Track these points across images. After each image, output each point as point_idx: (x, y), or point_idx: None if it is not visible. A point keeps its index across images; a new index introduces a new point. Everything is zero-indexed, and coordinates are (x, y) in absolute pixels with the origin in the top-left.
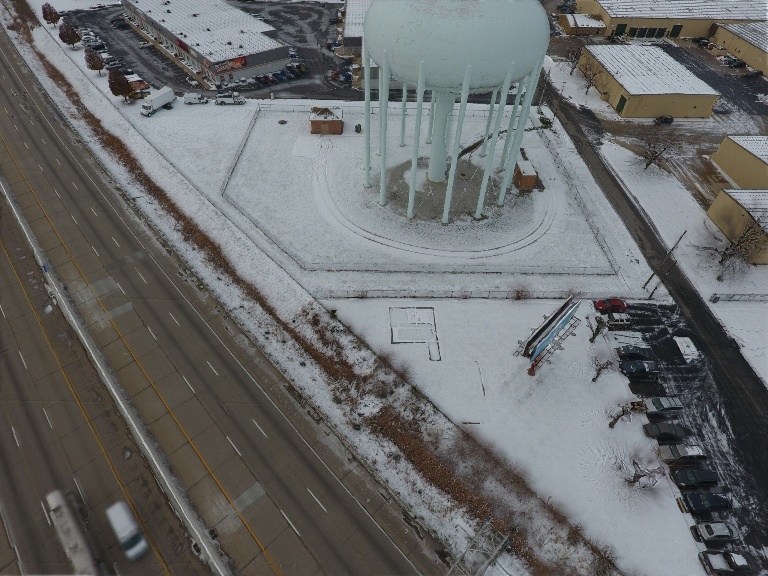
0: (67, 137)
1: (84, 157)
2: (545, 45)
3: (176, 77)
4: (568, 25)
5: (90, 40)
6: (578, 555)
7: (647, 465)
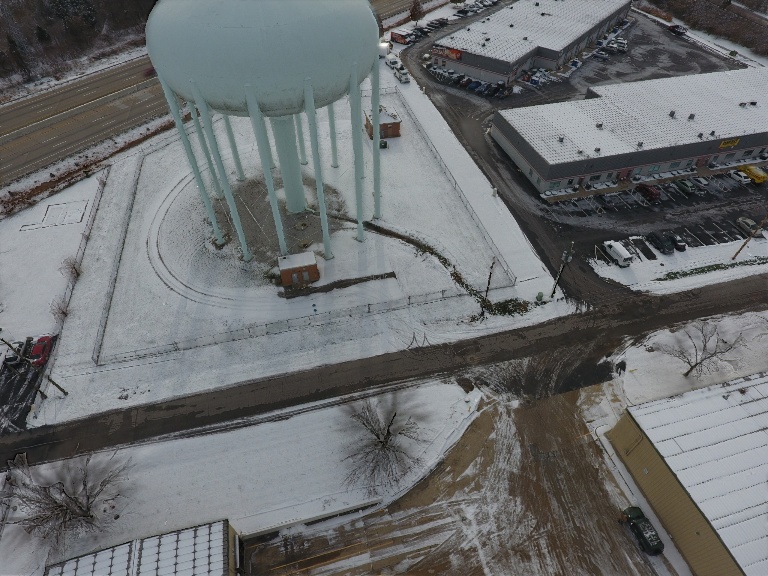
0: None
1: None
2: (200, 75)
3: None
4: None
5: (469, 5)
6: None
7: None
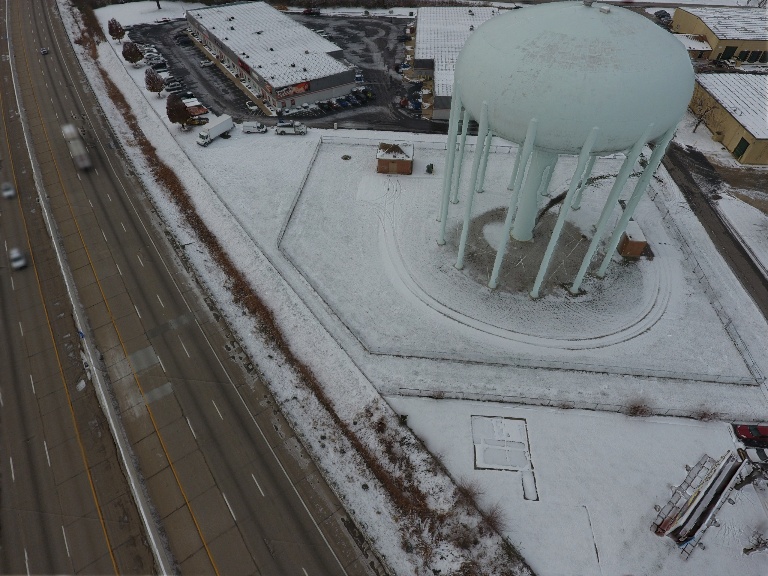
0: (121, 168)
1: (136, 192)
2: None
3: (236, 101)
4: None
5: (152, 58)
6: None
7: None
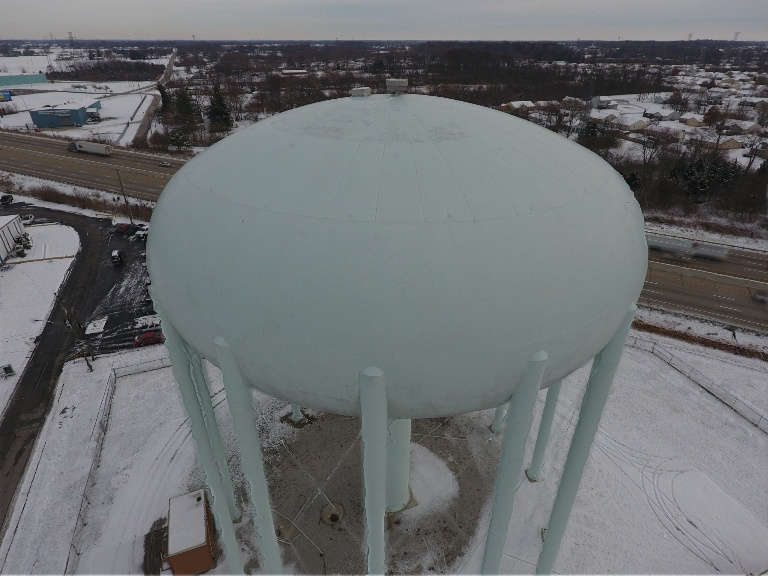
0: None
1: None
2: None
3: None
4: None
5: None
6: None
7: None
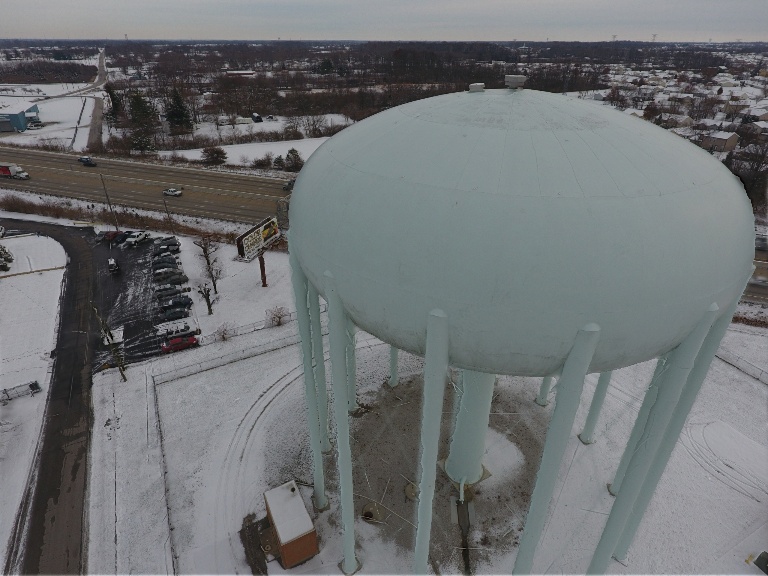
0: None
1: None
2: None
3: None
4: None
5: None
6: None
7: (193, 269)
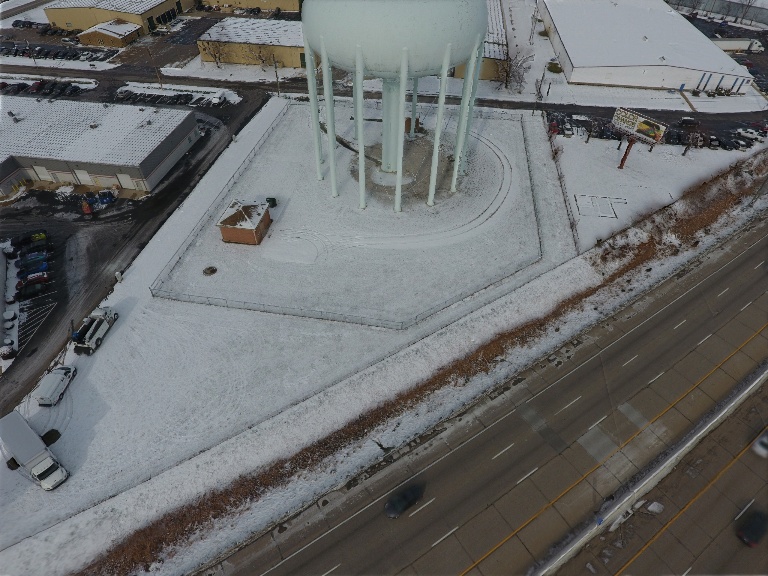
0: None
1: None
2: None
3: None
4: (111, 39)
5: None
6: (730, 180)
7: None
